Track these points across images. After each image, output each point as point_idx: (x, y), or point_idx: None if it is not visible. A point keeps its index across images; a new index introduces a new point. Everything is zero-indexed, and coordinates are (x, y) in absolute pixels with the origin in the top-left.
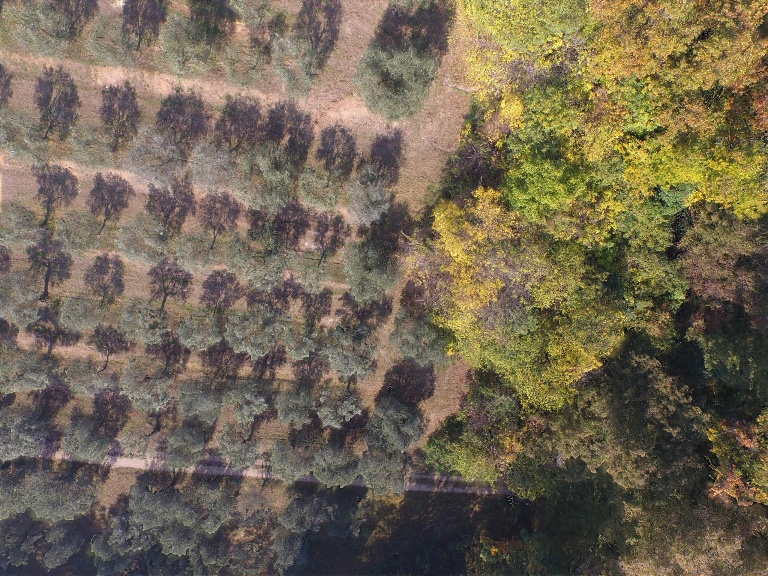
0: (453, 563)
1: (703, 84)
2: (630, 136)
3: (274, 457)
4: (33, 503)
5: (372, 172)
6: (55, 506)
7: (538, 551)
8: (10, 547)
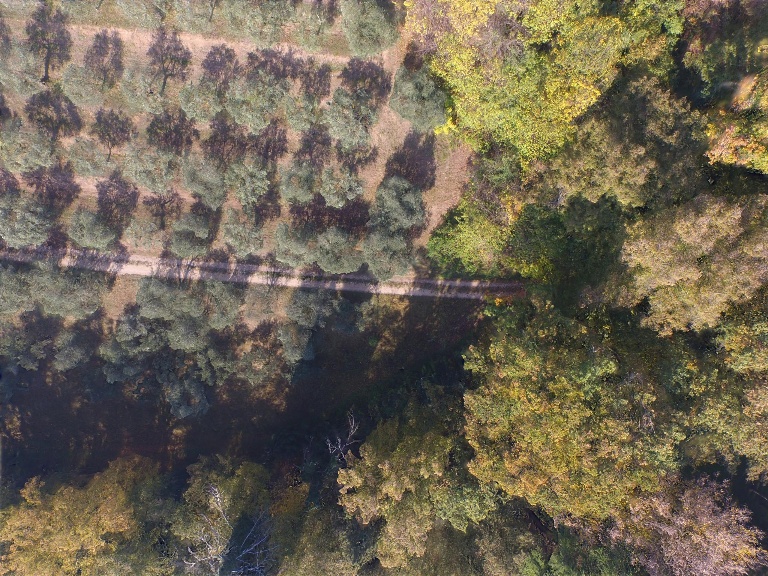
0: (459, 369)
1: None
2: None
3: (278, 233)
4: (41, 294)
5: None
6: (63, 294)
7: None
8: (20, 350)
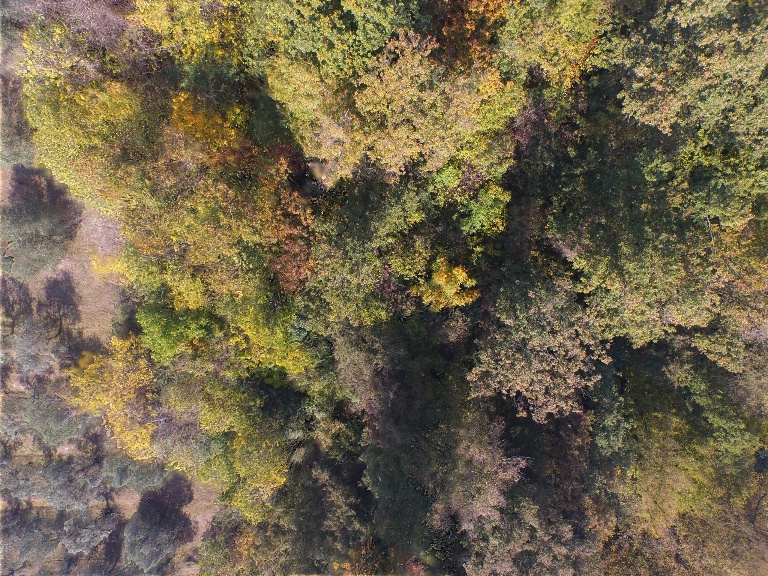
0: None
1: (207, 260)
2: None
3: None
4: None
5: None
6: None
7: None
8: None
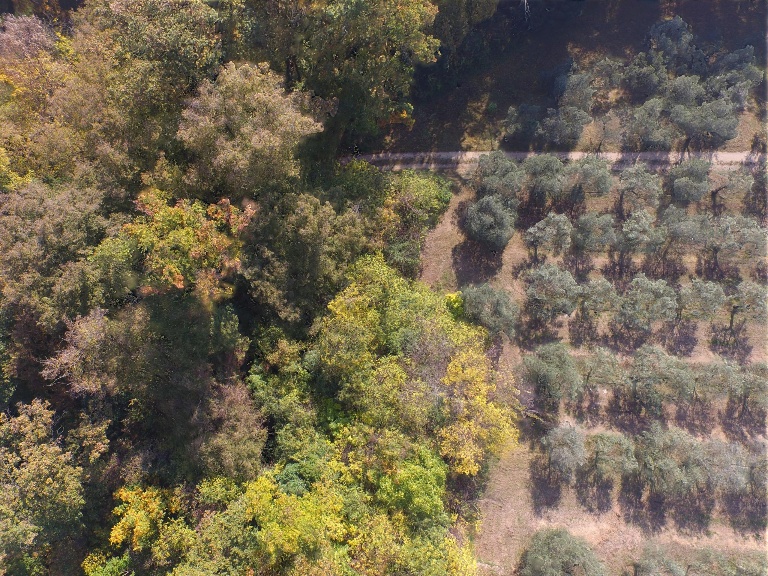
0: None
1: None
2: (341, 541)
3: None
4: None
5: None
6: None
7: None
8: None
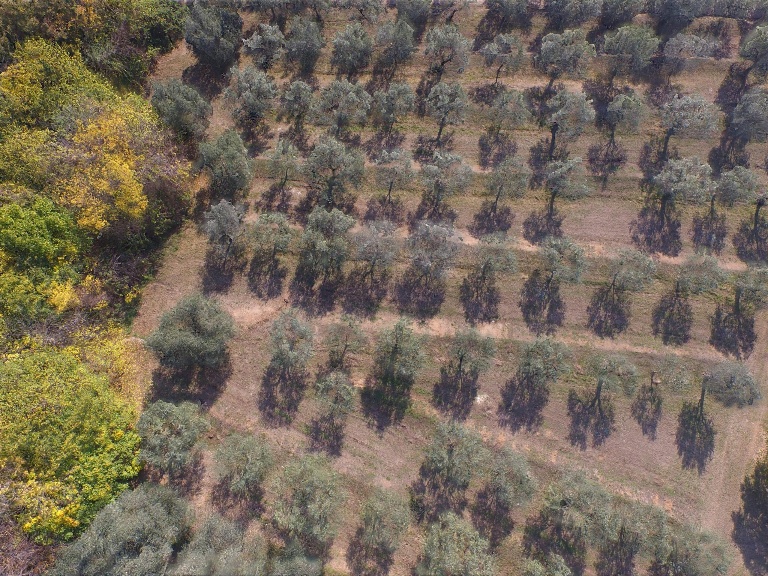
0: None
1: None
2: None
3: None
4: None
5: None
6: None
7: None
8: None
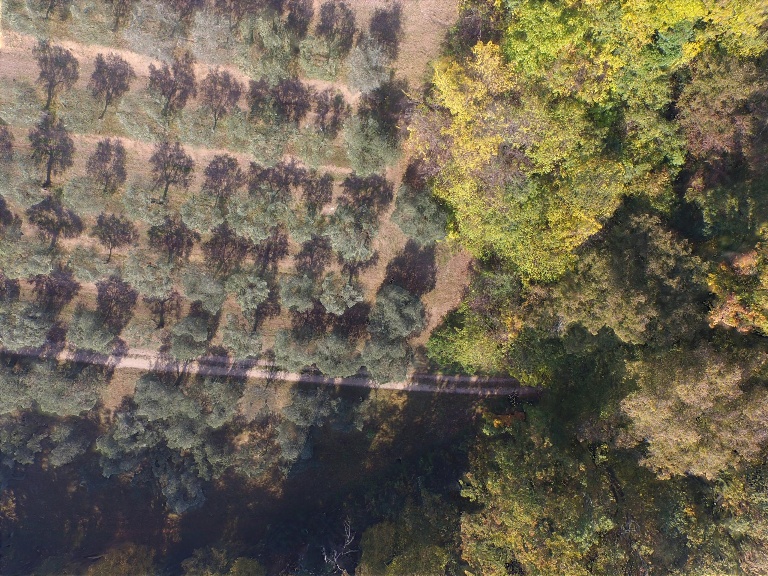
0: (456, 463)
1: None
2: None
3: (277, 342)
4: (39, 394)
5: (372, 38)
6: (60, 396)
7: (540, 418)
8: (16, 444)
